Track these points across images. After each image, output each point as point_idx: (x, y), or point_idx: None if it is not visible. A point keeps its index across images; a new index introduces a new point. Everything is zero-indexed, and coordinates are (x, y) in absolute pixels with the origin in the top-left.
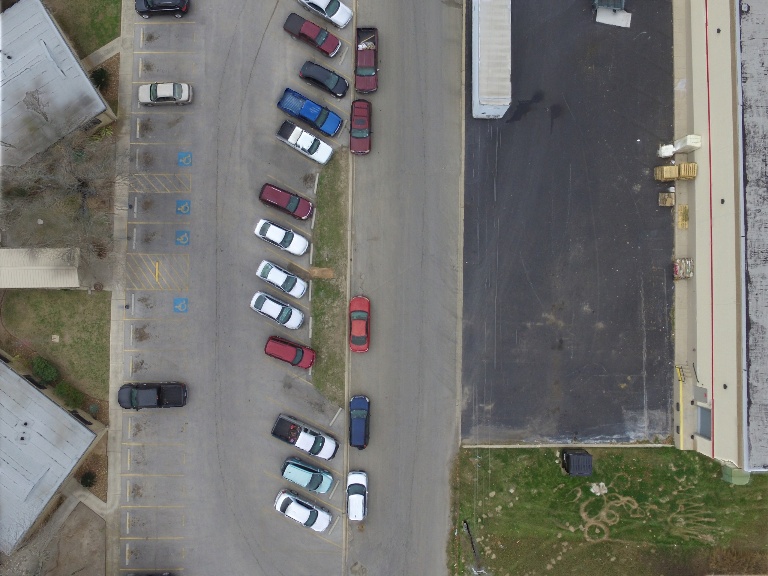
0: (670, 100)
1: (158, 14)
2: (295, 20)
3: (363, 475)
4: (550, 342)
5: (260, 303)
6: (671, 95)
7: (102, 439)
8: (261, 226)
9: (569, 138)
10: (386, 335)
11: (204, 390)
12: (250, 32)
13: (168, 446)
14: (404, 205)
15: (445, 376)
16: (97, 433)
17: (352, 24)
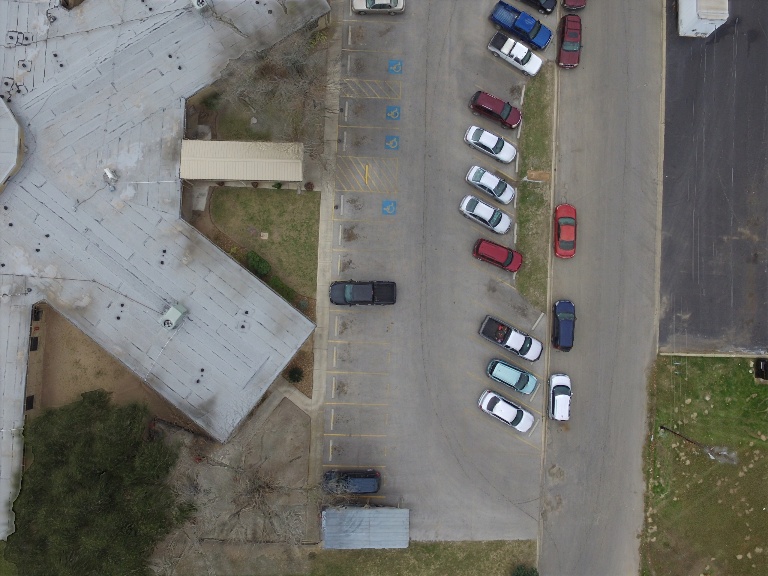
0: None
1: None
2: None
3: (567, 377)
4: (745, 256)
5: (472, 206)
6: None
7: None
8: (473, 132)
9: (765, 62)
10: (588, 243)
11: (410, 291)
12: None
13: (374, 345)
14: (608, 119)
15: (645, 285)
16: None
17: None
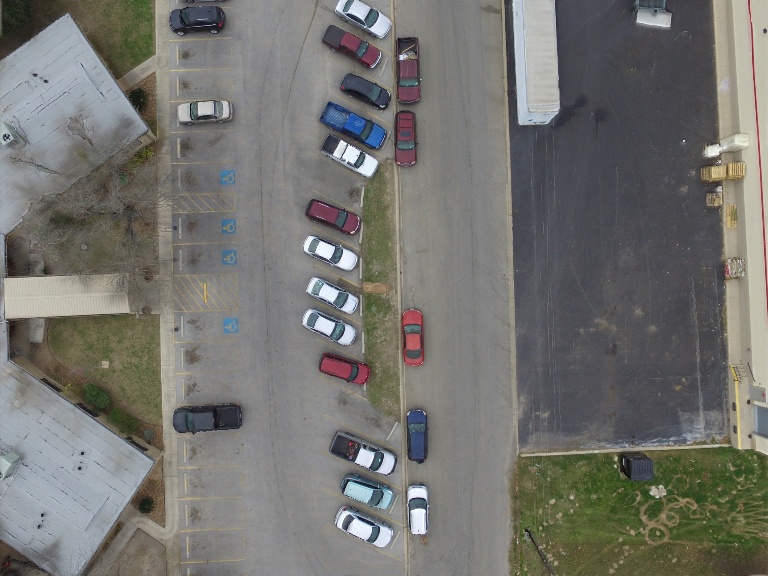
0: (714, 99)
1: (194, 31)
2: (334, 32)
3: (423, 489)
4: (604, 347)
5: (312, 321)
6: (715, 94)
7: (157, 464)
8: (310, 243)
9: (614, 141)
10: (439, 347)
11: (258, 410)
12: (288, 45)
13: (225, 468)
14: (452, 215)
15: (500, 386)
16: (155, 459)
17: (391, 34)
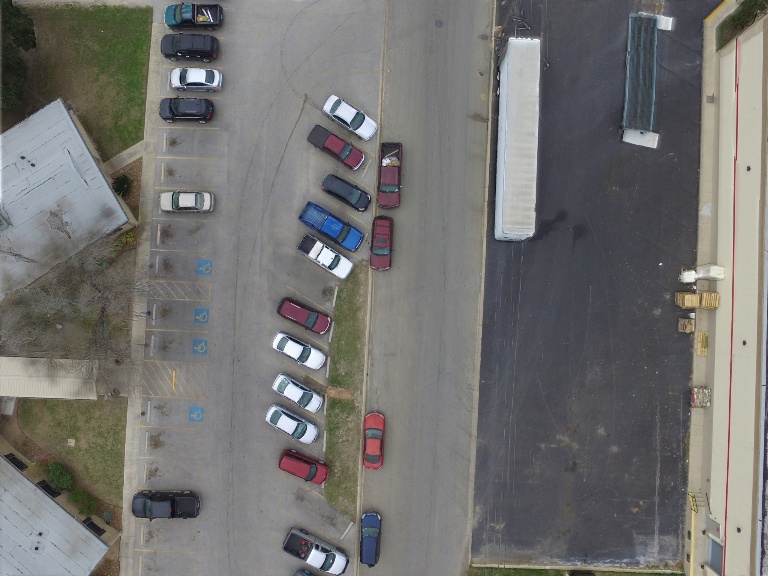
0: (694, 224)
1: (182, 120)
2: (319, 133)
3: None
4: (563, 464)
5: (276, 418)
6: (695, 219)
7: (115, 544)
8: (279, 340)
9: (591, 259)
10: (400, 451)
11: (217, 500)
12: (273, 140)
13: (180, 554)
14: (422, 322)
15: (457, 494)
16: None
17: (376, 136)
